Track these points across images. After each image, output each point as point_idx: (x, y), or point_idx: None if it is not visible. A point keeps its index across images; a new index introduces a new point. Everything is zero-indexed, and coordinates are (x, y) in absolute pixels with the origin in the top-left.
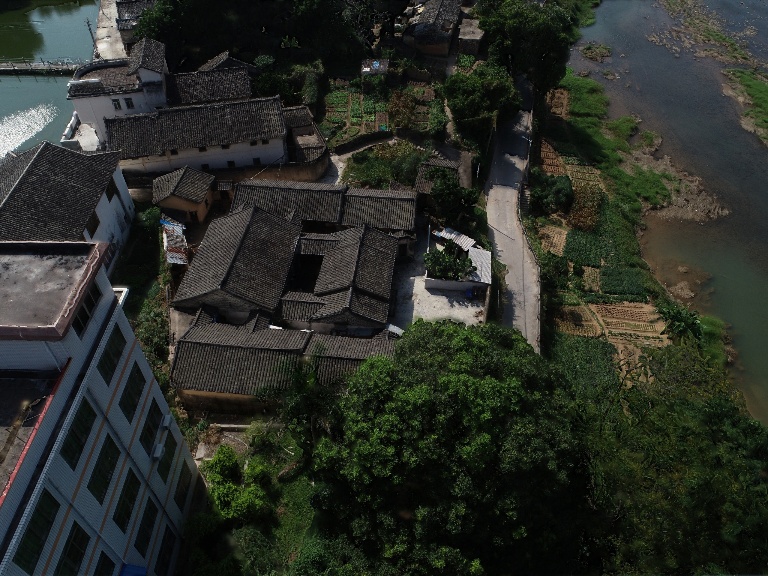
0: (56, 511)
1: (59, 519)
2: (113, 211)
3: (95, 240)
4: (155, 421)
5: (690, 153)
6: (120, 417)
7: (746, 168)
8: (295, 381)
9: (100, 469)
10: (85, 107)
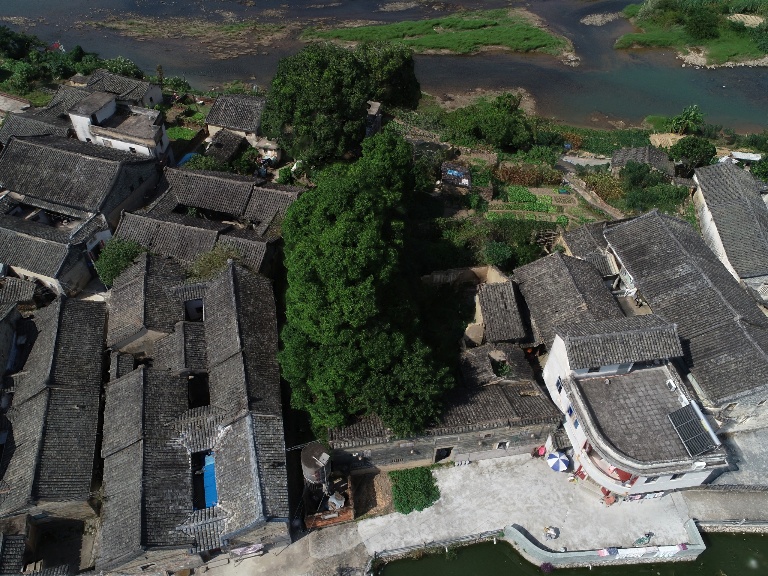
0: None
1: None
2: None
3: None
4: None
5: (441, 85)
6: None
7: (462, 69)
8: None
9: None
10: None
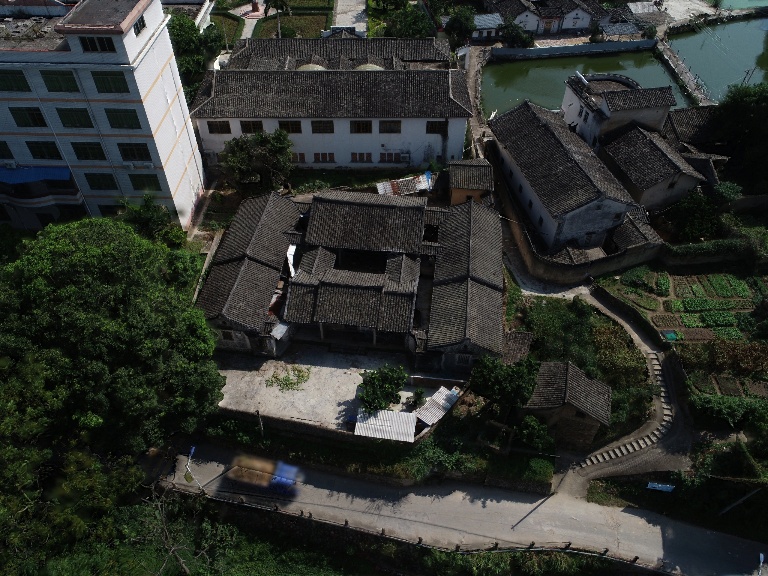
0: (28, 90)
1: (28, 95)
2: (426, 141)
3: (384, 137)
4: (142, 155)
5: None
6: (103, 115)
7: None
8: (146, 206)
9: (73, 115)
10: (569, 97)
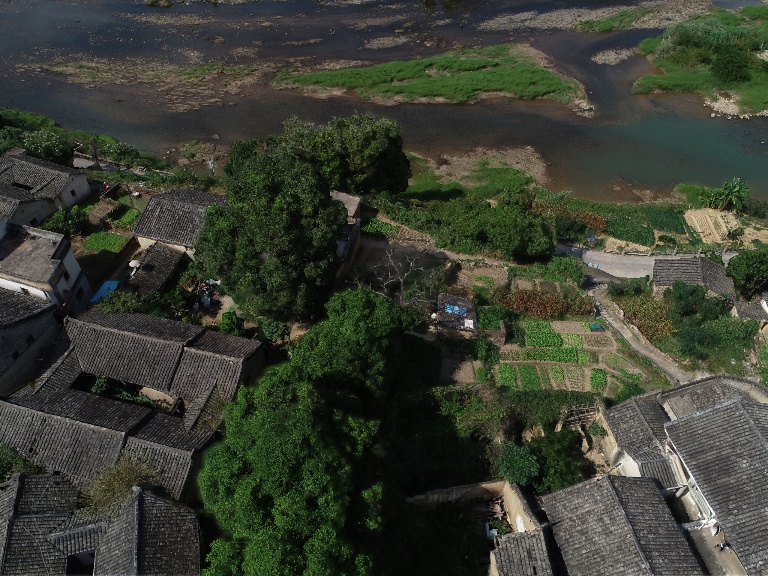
0: None
1: None
2: None
3: None
4: None
5: (436, 143)
6: None
7: (459, 122)
8: None
9: None
10: None
